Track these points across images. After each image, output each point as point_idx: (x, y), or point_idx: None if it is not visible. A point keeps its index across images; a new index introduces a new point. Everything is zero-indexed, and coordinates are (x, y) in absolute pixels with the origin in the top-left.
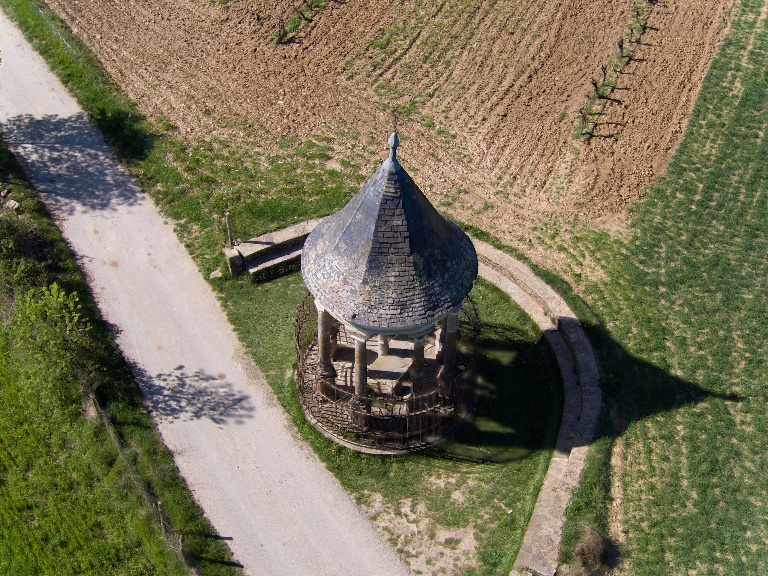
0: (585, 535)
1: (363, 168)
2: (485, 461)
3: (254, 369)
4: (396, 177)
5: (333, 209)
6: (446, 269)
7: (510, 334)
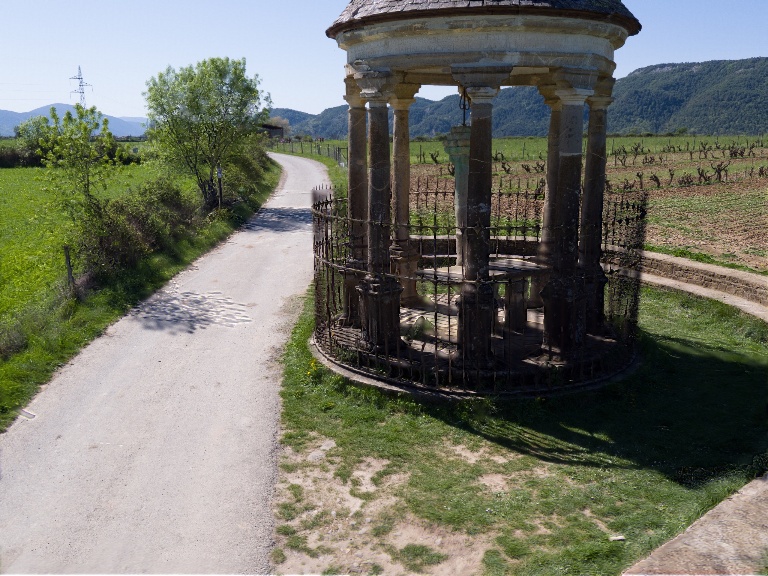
0: None
1: None
2: (595, 450)
3: (296, 307)
4: None
5: None
6: None
7: (727, 346)
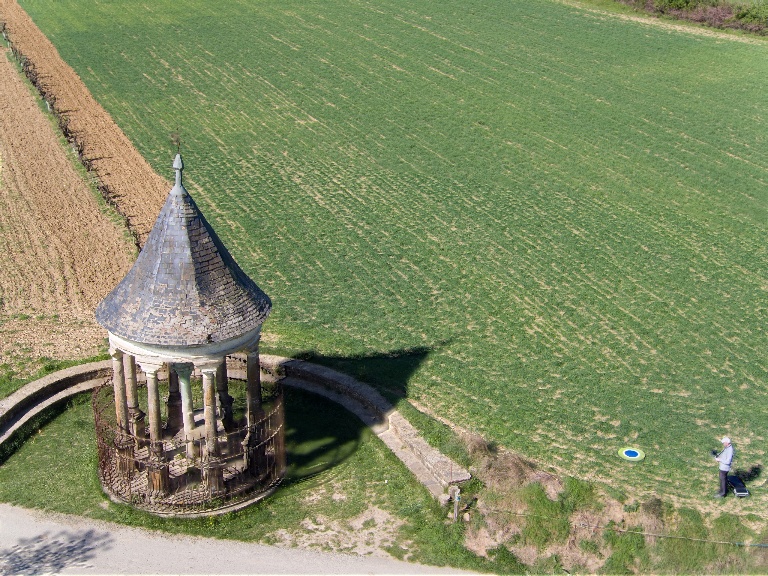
0: (464, 441)
1: (1, 360)
2: (331, 468)
3: (68, 518)
4: (189, 199)
5: (11, 389)
6: (248, 280)
7: None
